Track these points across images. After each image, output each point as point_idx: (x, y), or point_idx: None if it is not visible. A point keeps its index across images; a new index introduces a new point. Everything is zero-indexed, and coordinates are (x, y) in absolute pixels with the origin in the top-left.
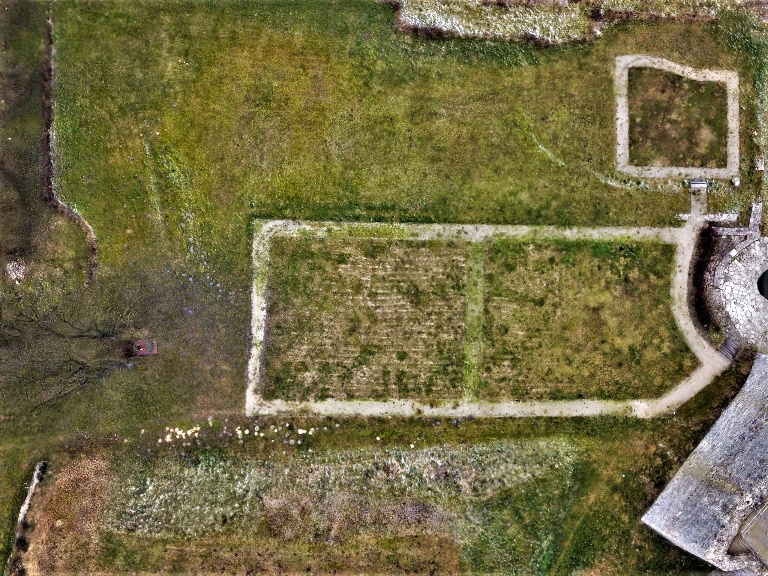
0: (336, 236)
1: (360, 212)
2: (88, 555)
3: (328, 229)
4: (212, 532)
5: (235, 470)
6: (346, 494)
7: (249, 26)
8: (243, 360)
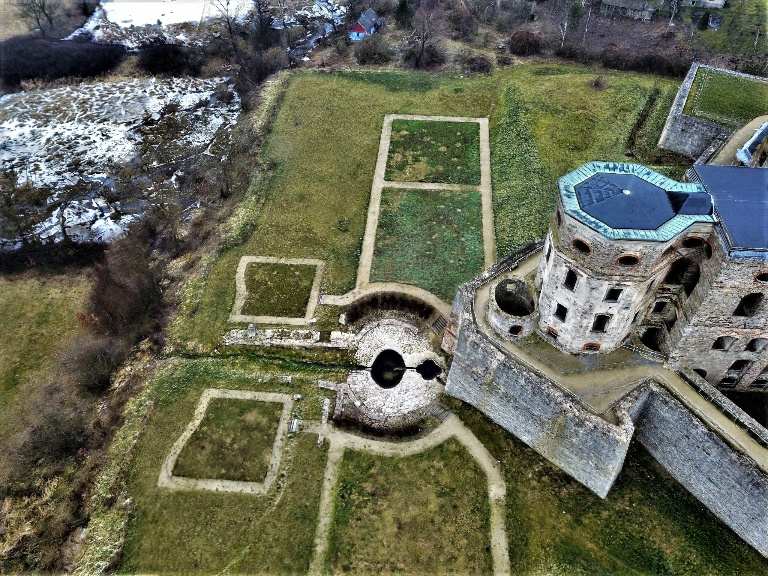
0: None
1: None
2: None
3: None
4: None
5: None
6: None
7: None
8: None
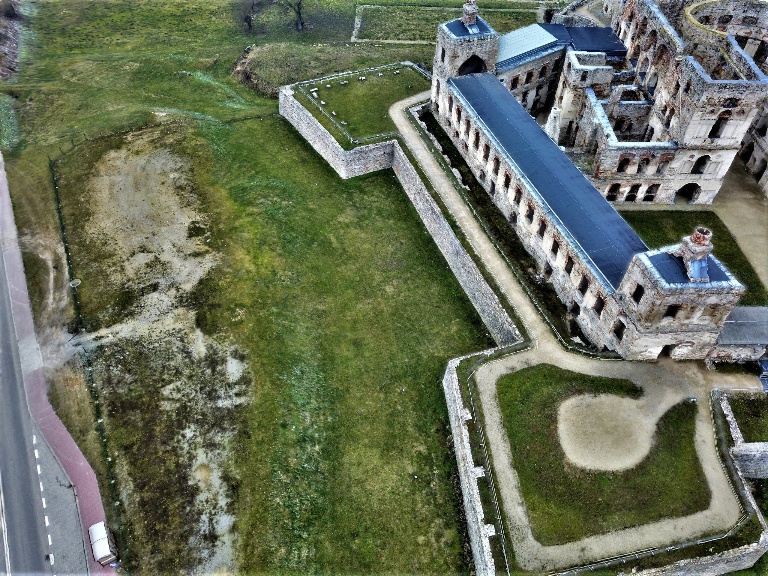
0: (392, 8)
1: (402, 4)
2: None
3: (388, 7)
4: None
5: None
6: None
7: None
8: None
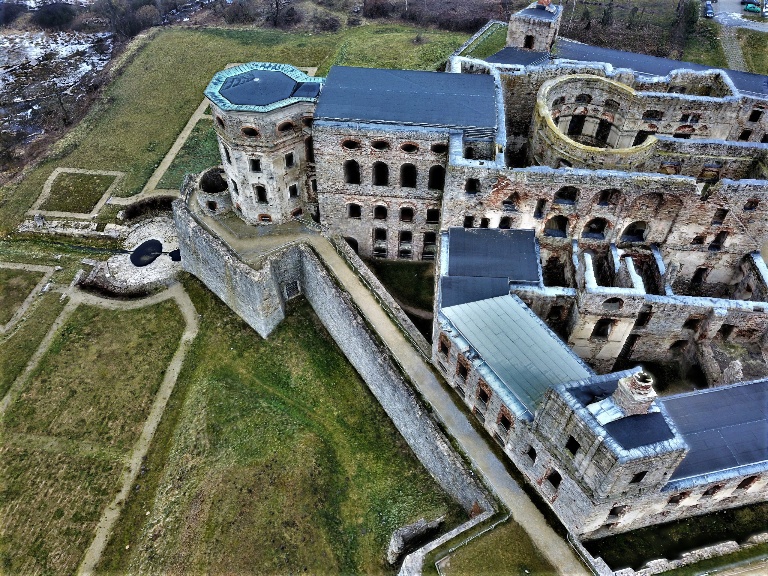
0: None
1: None
2: None
3: None
4: None
5: None
6: None
7: None
8: None
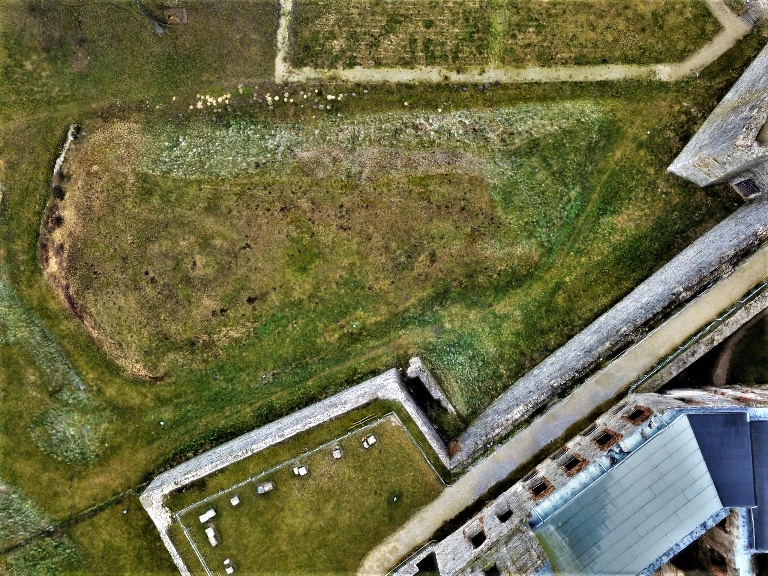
0: None
1: None
2: (124, 194)
3: None
4: (245, 174)
5: (266, 131)
6: (376, 148)
7: None
8: (272, 29)
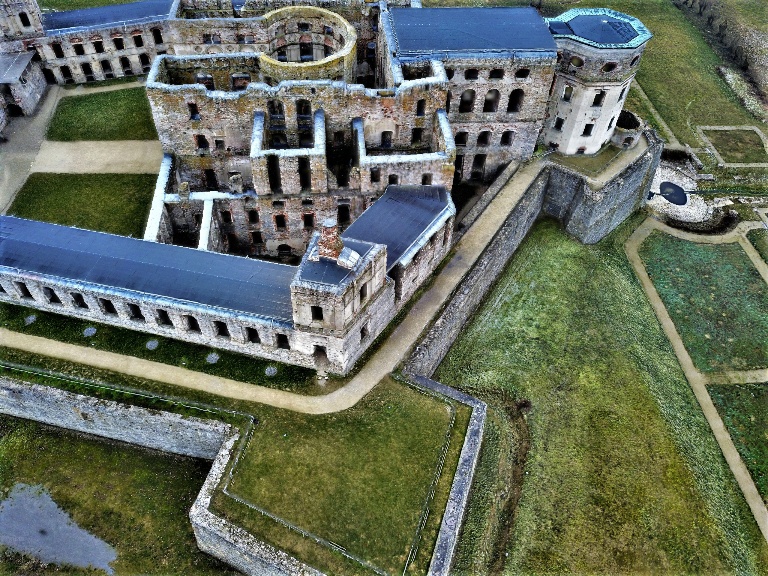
0: None
1: None
2: None
3: None
4: None
5: None
6: None
7: (686, 32)
8: None
